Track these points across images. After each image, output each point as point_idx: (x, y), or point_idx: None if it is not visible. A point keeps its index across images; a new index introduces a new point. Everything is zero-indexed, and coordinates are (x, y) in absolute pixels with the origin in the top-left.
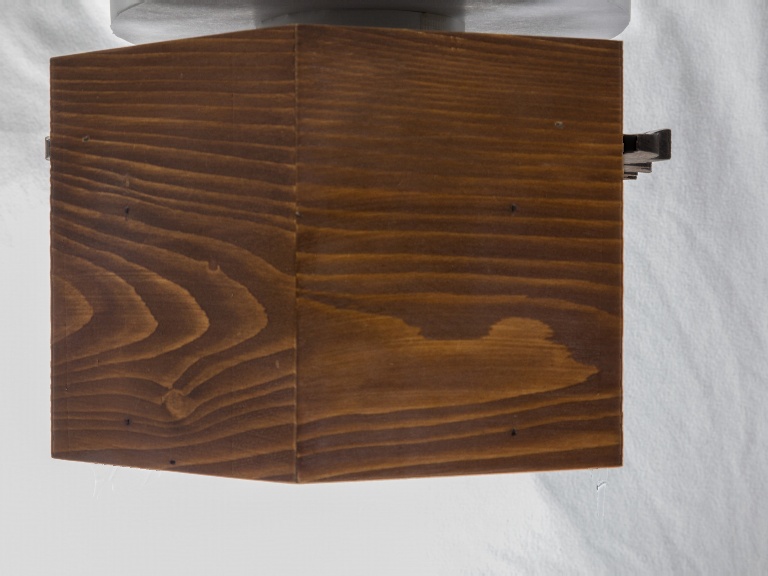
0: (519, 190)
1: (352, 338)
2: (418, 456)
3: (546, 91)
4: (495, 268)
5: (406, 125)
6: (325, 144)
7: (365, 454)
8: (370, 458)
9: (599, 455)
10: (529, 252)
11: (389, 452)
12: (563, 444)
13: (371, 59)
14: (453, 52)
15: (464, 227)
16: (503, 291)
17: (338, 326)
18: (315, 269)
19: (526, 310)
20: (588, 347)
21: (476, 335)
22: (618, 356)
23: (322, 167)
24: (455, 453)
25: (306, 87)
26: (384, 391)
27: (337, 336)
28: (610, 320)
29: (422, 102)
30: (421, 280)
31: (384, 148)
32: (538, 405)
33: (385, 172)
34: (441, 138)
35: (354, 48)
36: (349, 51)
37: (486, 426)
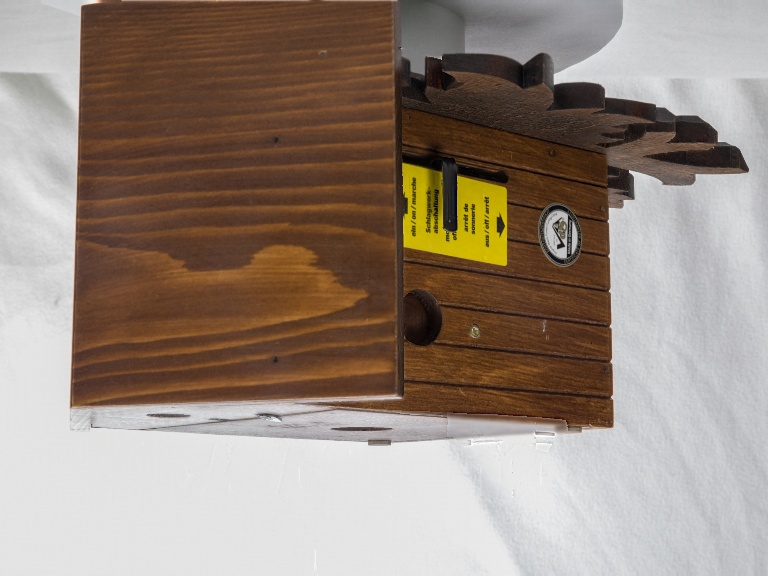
0: (282, 122)
1: (122, 273)
2: (180, 382)
3: (309, 23)
4: (257, 199)
5: (174, 76)
6: (103, 103)
7: (131, 380)
8: (136, 384)
9: (368, 383)
10: (292, 180)
11: (153, 378)
12: (328, 371)
13: (143, 23)
14: (218, 4)
15: (227, 163)
16: (265, 220)
17: (110, 263)
18: (92, 214)
19: (289, 237)
20: (356, 271)
21: (238, 265)
22: (390, 279)
23: (100, 124)
24: (216, 380)
25: (88, 57)
26: (150, 321)
27: (109, 272)
28: (380, 242)
29: (189, 54)
30: (186, 216)
31: (154, 100)
32: (302, 332)
33: (155, 121)
34: (206, 83)
35: (129, 17)
36: (124, 20)
37: (247, 353)
